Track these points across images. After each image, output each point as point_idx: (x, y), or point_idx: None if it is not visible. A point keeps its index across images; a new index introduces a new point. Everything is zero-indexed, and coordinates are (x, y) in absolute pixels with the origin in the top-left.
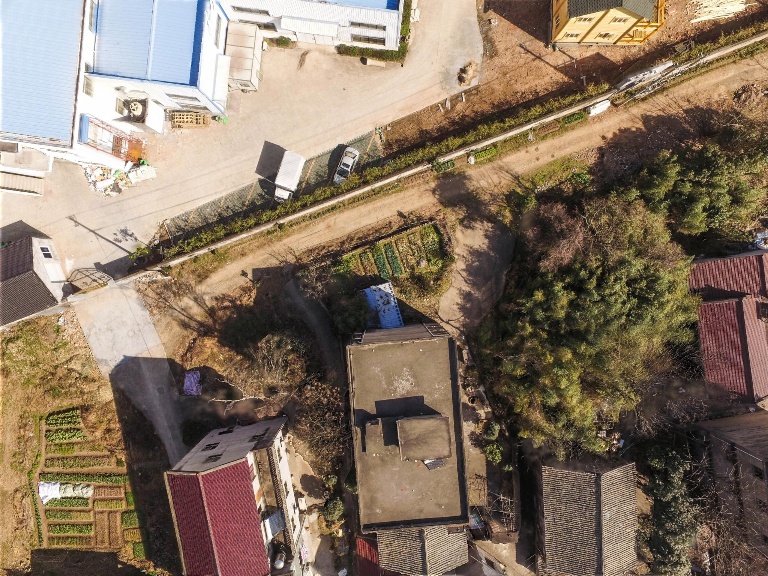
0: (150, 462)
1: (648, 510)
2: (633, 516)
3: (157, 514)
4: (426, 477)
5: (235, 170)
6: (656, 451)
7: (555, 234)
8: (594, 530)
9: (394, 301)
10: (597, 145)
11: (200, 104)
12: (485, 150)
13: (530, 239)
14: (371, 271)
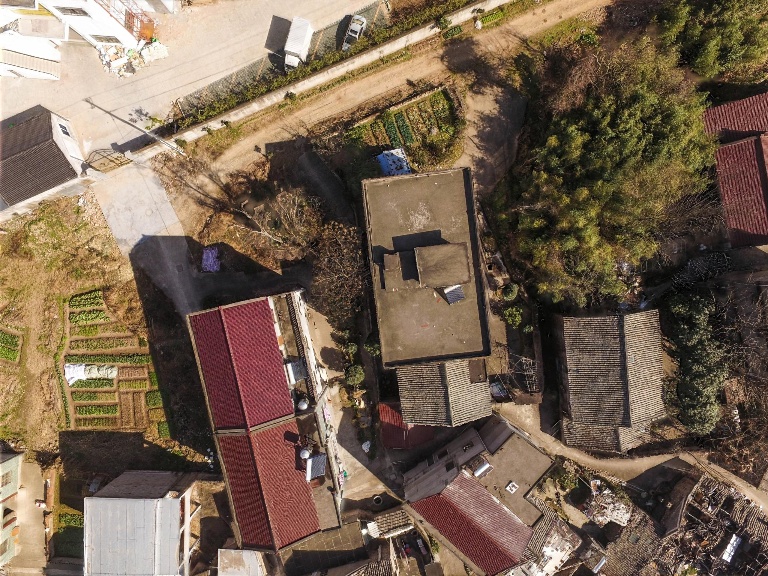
0: (172, 340)
1: None
2: (659, 364)
3: (180, 391)
4: (446, 312)
5: (245, 46)
6: (679, 298)
7: (566, 65)
8: (619, 374)
9: (407, 166)
10: (605, 4)
11: None
12: (492, 14)
13: (541, 79)
14: (383, 141)
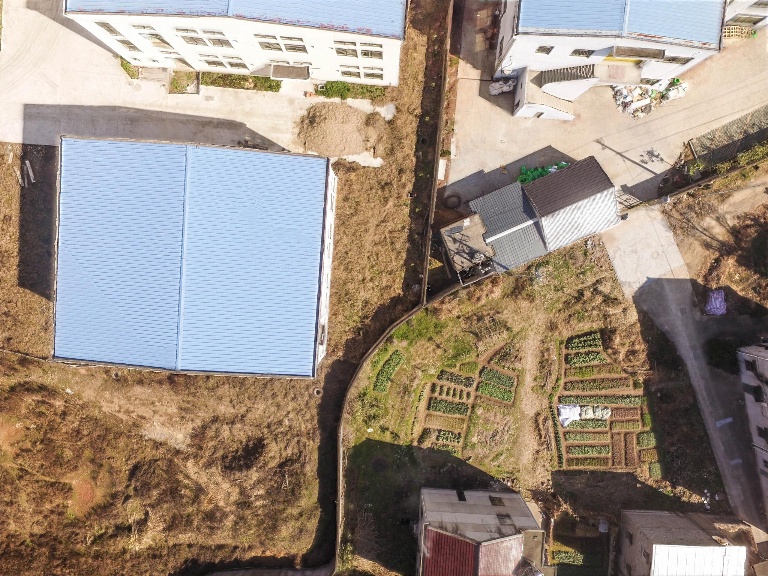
0: (671, 382)
1: None
2: None
3: (679, 433)
4: None
5: (764, 85)
6: None
7: None
8: None
9: None
10: None
11: (767, 13)
12: None
13: None
14: None
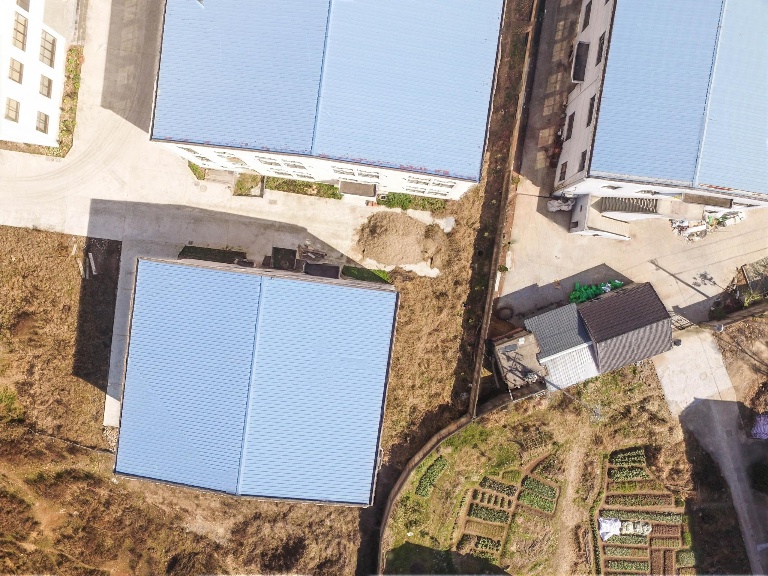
0: (714, 503)
1: None
2: None
3: (720, 555)
4: None
5: None
6: None
7: None
8: None
9: None
10: None
11: None
12: None
13: None
14: None
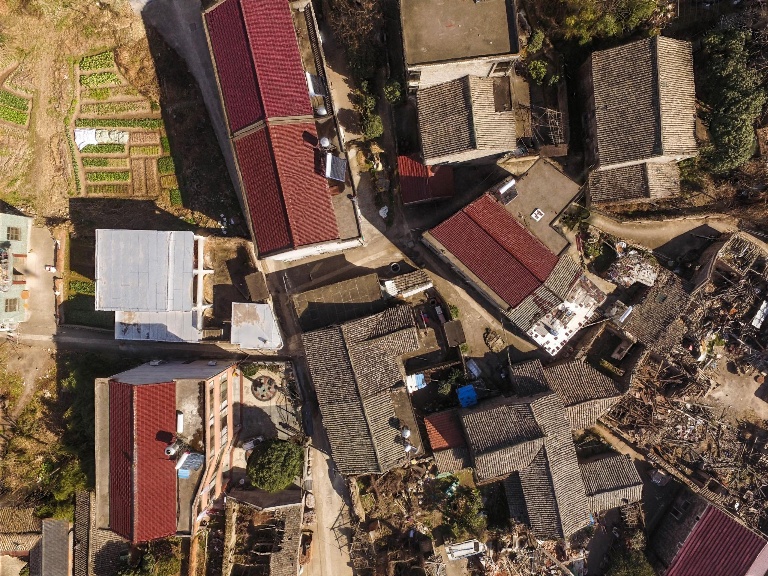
0: (185, 102)
1: (704, 135)
2: (691, 98)
3: (193, 155)
4: (472, 11)
5: None
6: (713, 33)
7: None
8: (651, 100)
9: None
10: None
11: None
12: None
13: None
14: None
